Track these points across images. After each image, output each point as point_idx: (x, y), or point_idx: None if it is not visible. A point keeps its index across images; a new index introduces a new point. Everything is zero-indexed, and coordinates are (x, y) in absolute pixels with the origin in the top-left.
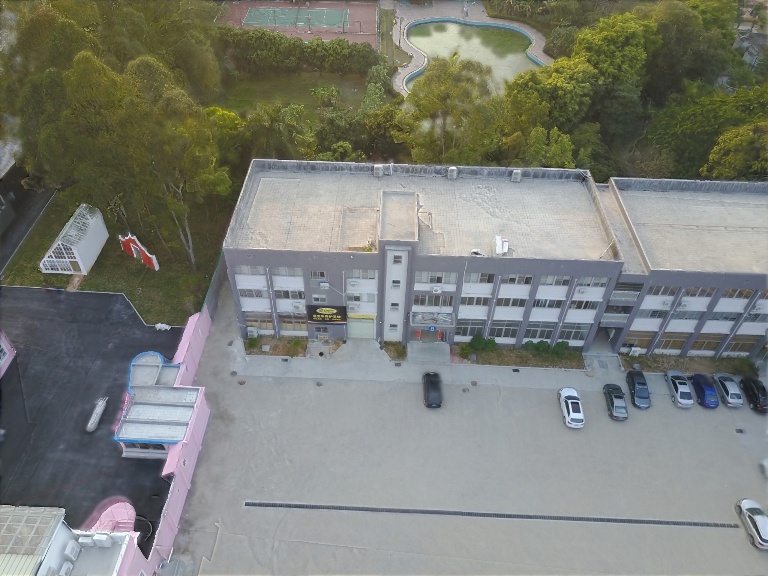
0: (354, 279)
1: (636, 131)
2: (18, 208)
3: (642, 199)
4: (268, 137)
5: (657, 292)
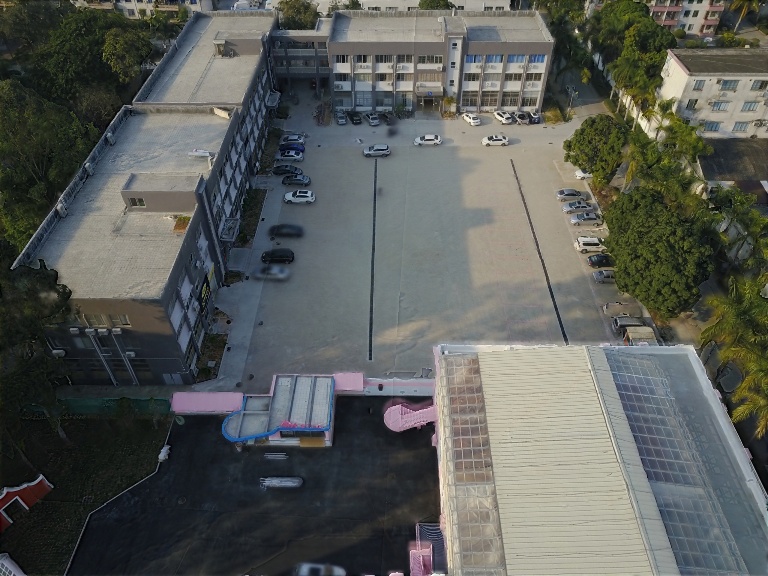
0: (198, 244)
1: None
2: None
3: (157, 100)
4: None
5: None
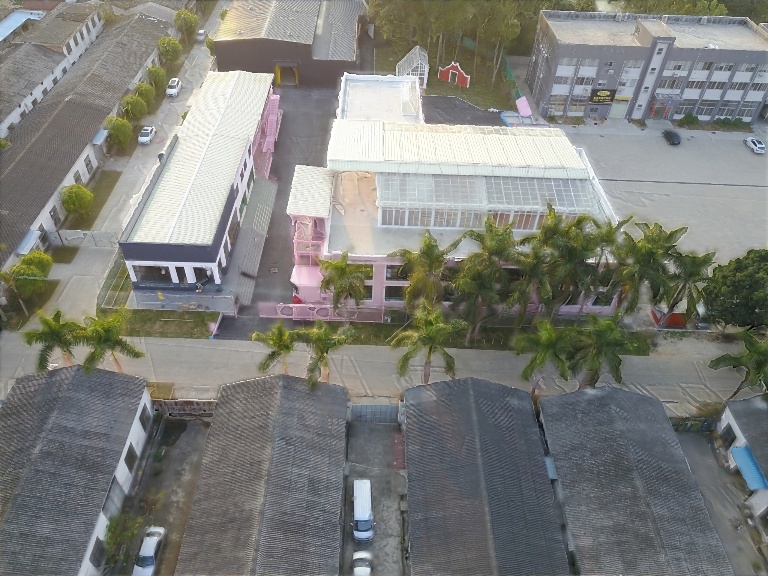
0: (628, 68)
1: None
2: None
3: None
4: None
5: None
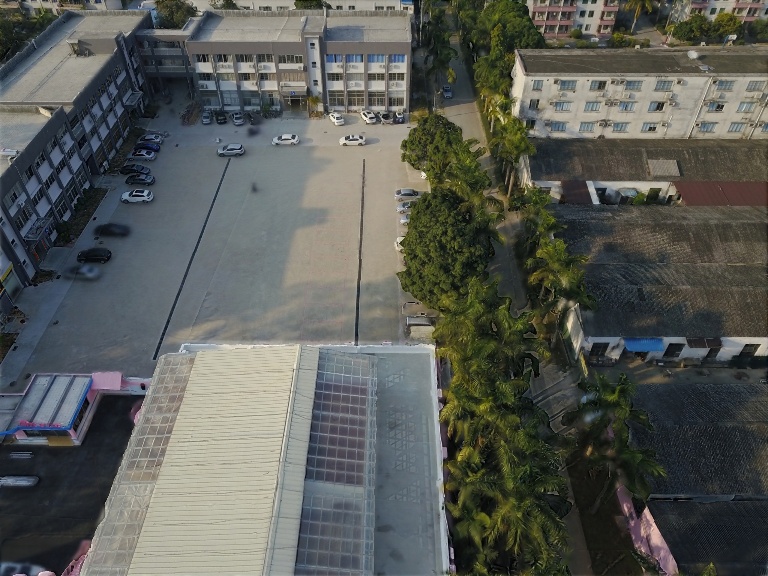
0: None
1: None
2: None
3: None
4: None
5: (82, 117)
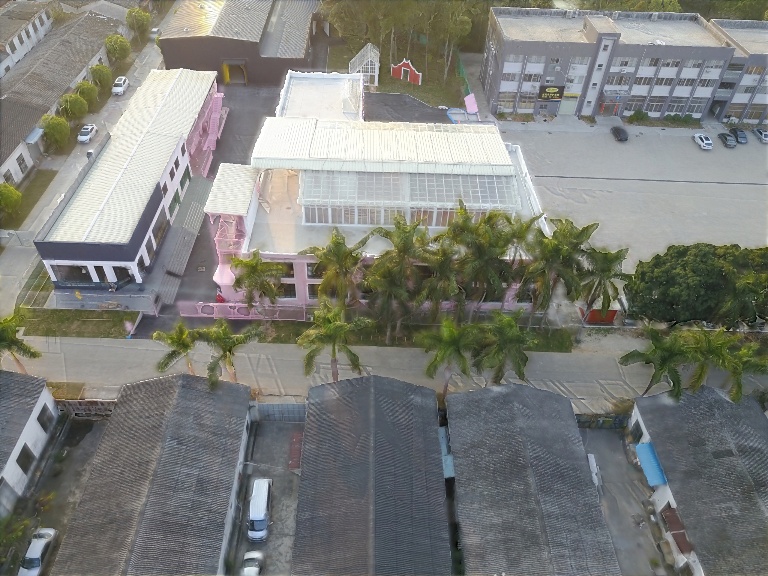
0: (575, 65)
1: (704, 16)
2: (313, 53)
3: (731, 31)
4: (487, 1)
5: (751, 72)
